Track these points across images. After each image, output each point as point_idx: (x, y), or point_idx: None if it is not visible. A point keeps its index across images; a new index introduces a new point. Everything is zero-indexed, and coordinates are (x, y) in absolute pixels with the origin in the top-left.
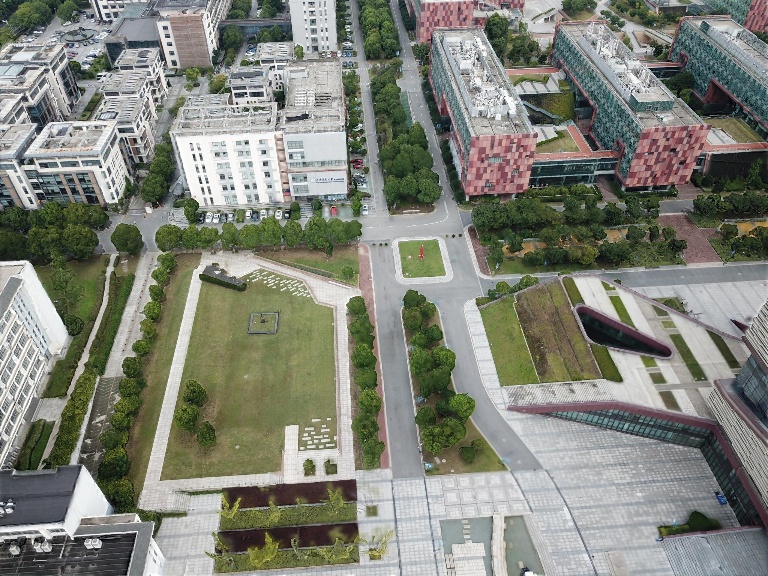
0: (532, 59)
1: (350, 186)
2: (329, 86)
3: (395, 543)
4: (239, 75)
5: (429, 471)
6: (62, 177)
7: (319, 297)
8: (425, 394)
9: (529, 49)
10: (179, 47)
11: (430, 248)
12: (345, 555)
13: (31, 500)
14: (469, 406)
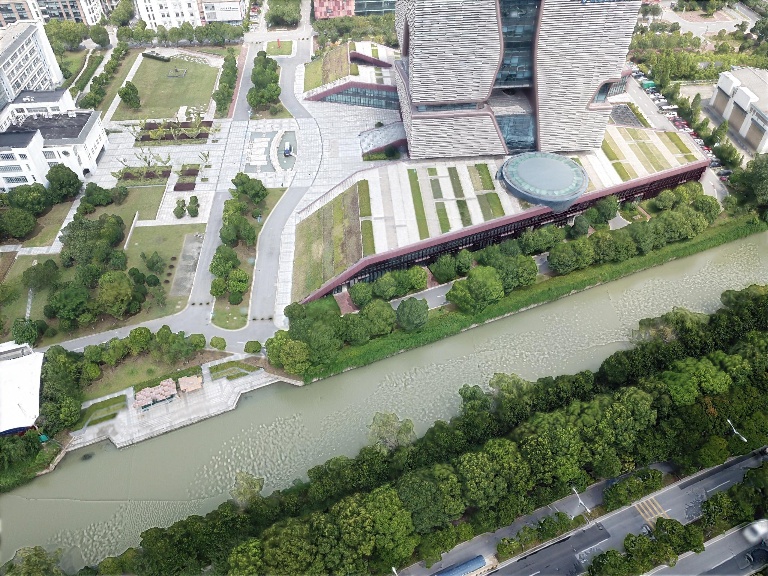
0: None
1: None
2: None
3: (226, 139)
4: None
5: (252, 118)
6: (60, 4)
7: (213, 64)
8: (256, 88)
9: None
10: None
11: (286, 44)
12: (196, 131)
13: (42, 98)
14: (276, 89)
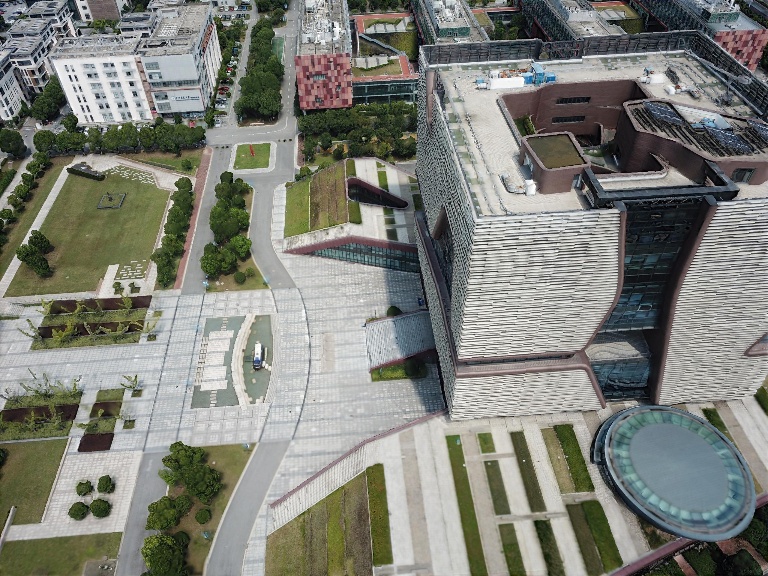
0: (402, 9)
1: (211, 107)
2: (194, 23)
3: (169, 331)
4: (129, 19)
5: (209, 290)
6: None
7: (162, 184)
8: (216, 239)
9: (401, 1)
10: (90, 2)
11: (262, 149)
12: (121, 331)
13: None
14: (244, 244)
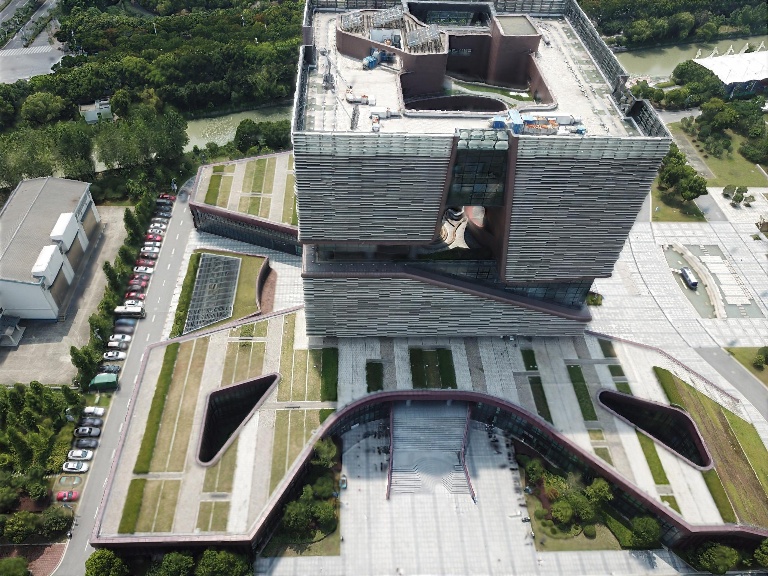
0: None
1: None
2: None
3: None
4: None
5: None
6: None
7: None
8: None
9: None
10: None
11: None
12: None
13: None
14: None
